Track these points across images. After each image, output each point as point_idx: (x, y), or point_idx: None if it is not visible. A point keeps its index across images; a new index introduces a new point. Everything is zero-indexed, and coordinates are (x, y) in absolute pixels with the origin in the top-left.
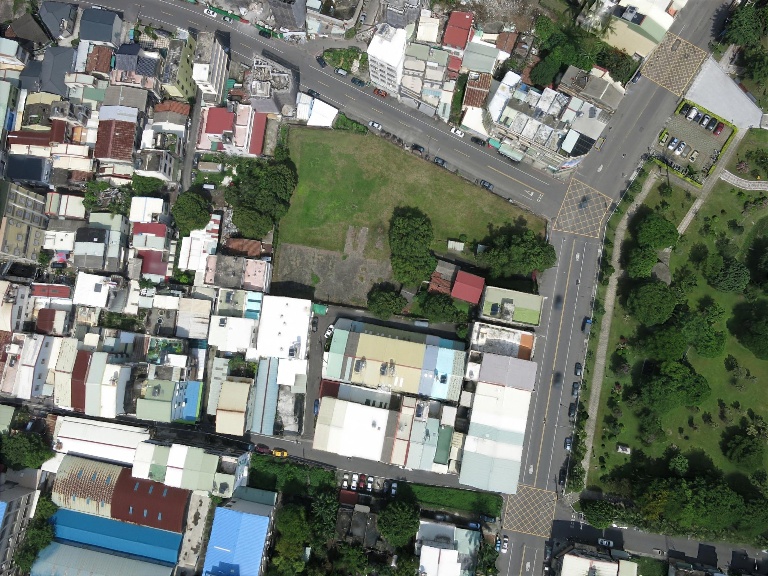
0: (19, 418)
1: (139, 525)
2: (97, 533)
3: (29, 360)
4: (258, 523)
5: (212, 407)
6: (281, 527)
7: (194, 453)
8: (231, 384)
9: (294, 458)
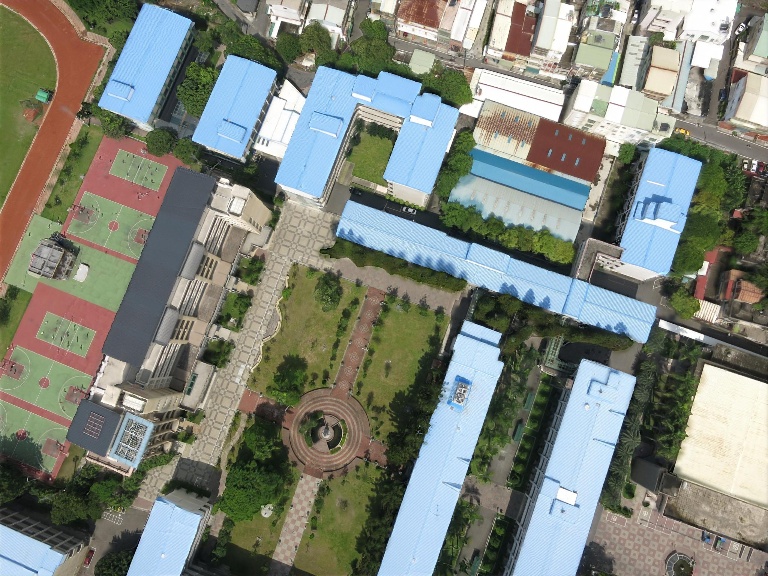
0: (434, 69)
1: (549, 172)
2: (512, 172)
3: (467, 5)
4: (692, 165)
5: (626, 78)
6: (703, 179)
7: (635, 95)
8: (662, 49)
9: (695, 139)
